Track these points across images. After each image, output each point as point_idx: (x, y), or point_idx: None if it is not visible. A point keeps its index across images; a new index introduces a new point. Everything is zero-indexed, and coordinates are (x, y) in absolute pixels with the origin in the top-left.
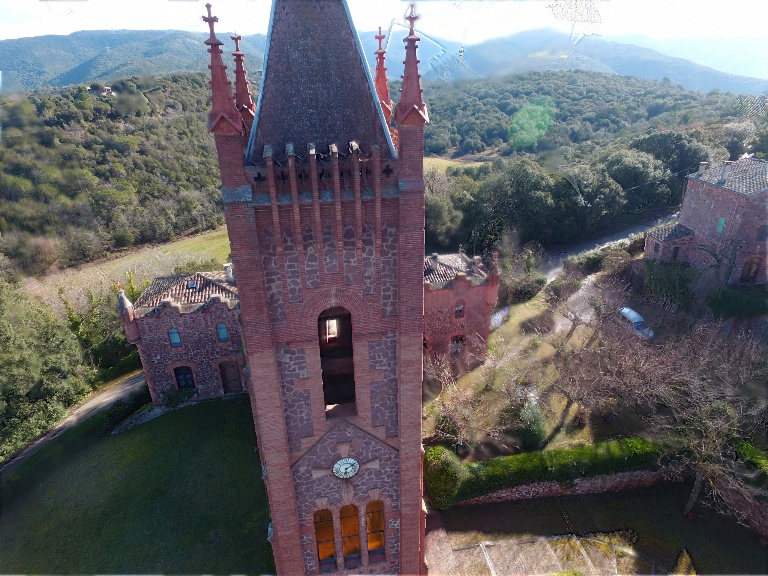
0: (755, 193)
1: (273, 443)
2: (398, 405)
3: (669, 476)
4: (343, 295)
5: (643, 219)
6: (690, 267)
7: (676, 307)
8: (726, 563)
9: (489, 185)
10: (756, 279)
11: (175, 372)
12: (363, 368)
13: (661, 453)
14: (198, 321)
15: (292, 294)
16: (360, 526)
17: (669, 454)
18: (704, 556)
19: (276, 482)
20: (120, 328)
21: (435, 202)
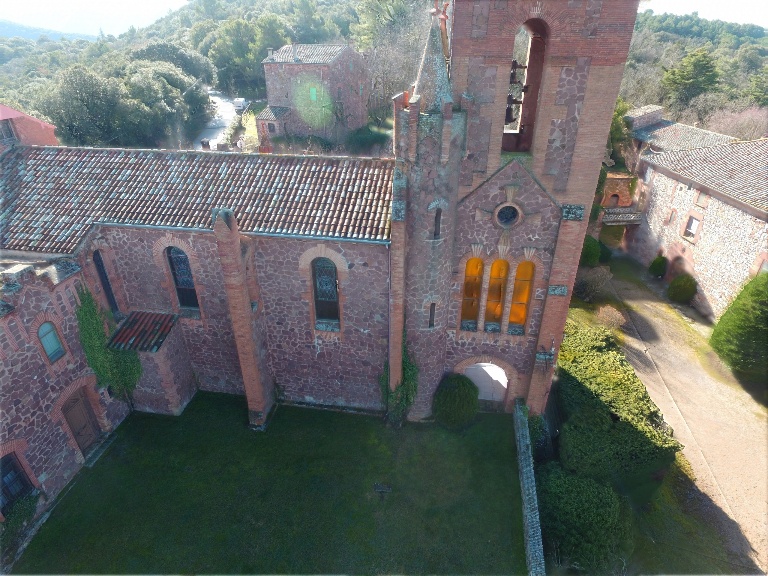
0: (331, 62)
1: None
2: None
3: None
4: None
5: (200, 125)
6: (299, 137)
7: (346, 151)
8: None
9: (51, 102)
10: None
11: None
12: None
13: None
14: None
15: None
16: None
17: None
18: None
19: None
20: None
21: None
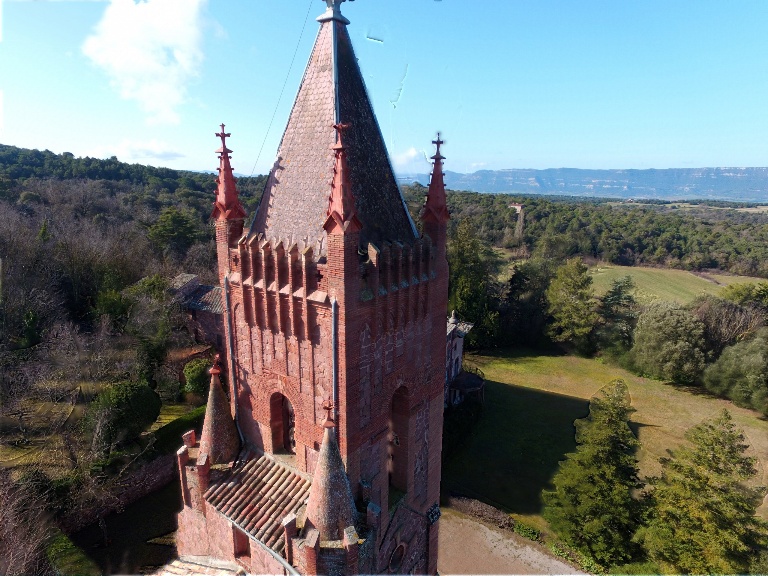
0: None
1: None
2: None
3: (121, 508)
4: None
5: None
6: None
7: None
8: (149, 524)
9: None
10: None
11: None
12: None
13: (103, 505)
14: None
15: None
16: None
17: (104, 500)
18: (148, 533)
19: None
20: None
21: None
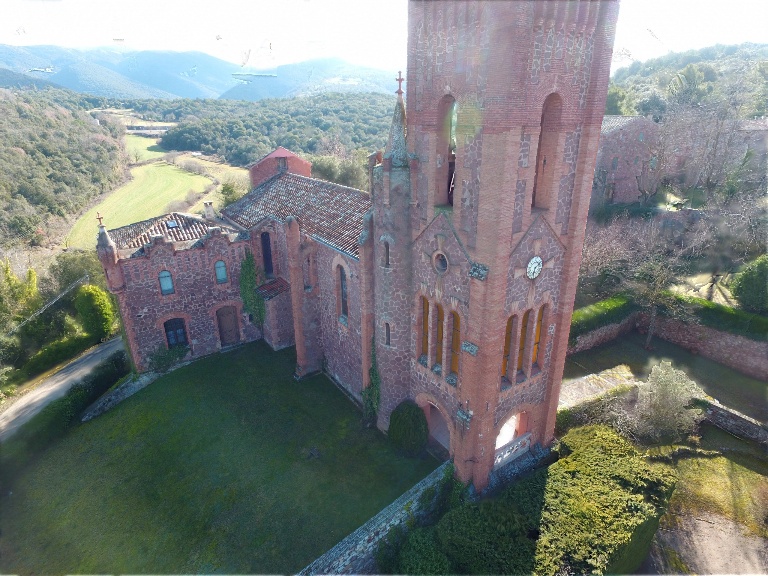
0: (609, 132)
1: (504, 232)
2: (572, 201)
3: (644, 311)
4: (561, 82)
5: None
6: None
7: None
8: (684, 368)
9: None
10: (613, 200)
11: (165, 327)
12: (559, 160)
13: (634, 297)
14: (194, 260)
15: (533, 76)
16: (532, 333)
17: None
18: None
19: (498, 278)
20: (4, 329)
21: (352, 165)
